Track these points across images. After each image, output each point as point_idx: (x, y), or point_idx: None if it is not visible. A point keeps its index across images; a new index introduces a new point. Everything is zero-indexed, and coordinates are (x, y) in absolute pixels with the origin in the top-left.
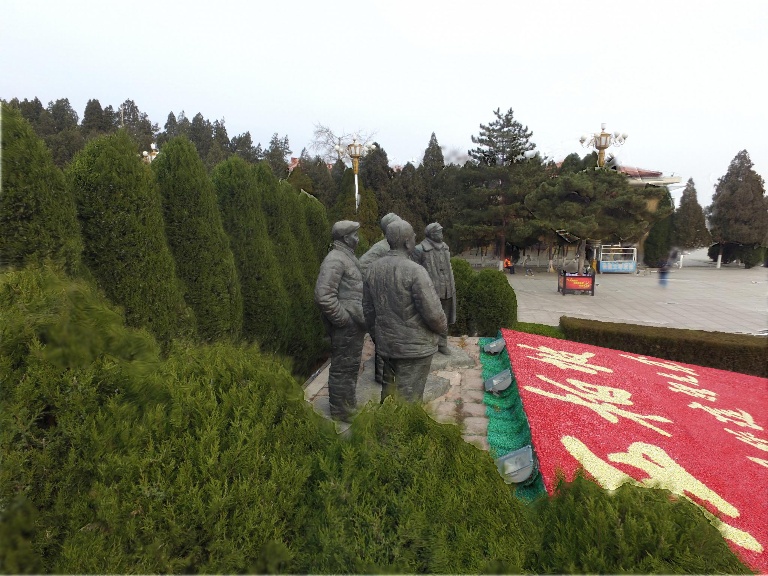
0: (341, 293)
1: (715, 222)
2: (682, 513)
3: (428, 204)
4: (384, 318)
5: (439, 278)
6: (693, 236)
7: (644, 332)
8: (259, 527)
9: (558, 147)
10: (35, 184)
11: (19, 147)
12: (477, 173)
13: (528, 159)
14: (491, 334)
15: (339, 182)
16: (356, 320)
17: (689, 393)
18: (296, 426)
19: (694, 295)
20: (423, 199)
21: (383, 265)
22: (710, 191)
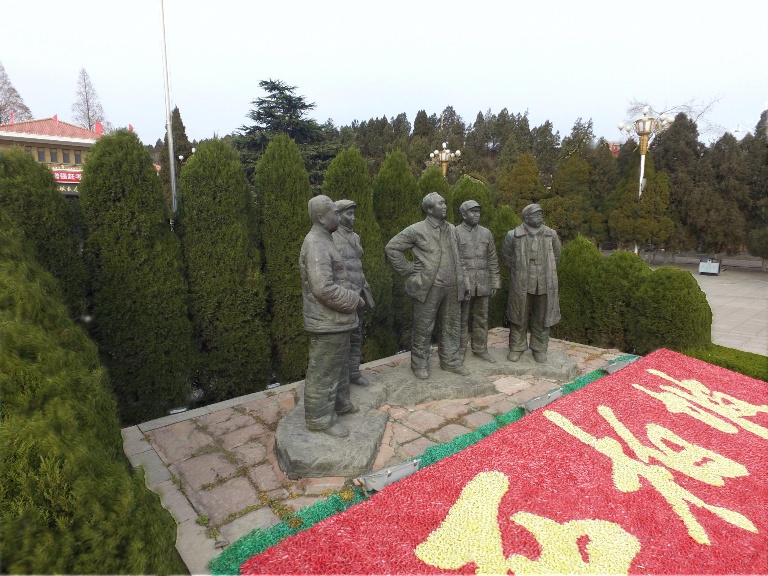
0: None
1: None
2: (6, 462)
3: (752, 187)
4: None
5: (528, 269)
6: None
7: None
8: None
9: None
10: (124, 178)
11: (119, 155)
12: None
13: None
14: None
15: (623, 165)
16: None
17: None
18: None
19: None
20: (744, 180)
21: None
22: None
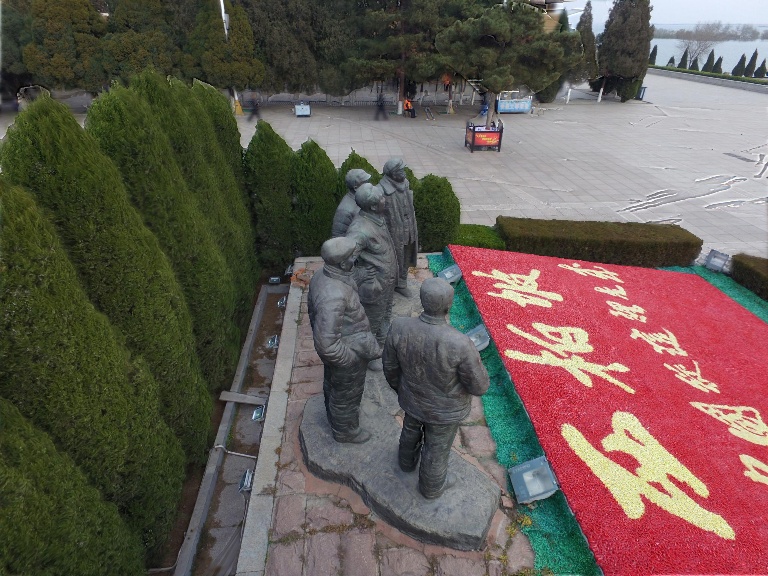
0: (343, 330)
1: (604, 53)
2: None
3: (314, 27)
4: (419, 388)
5: (403, 225)
6: (583, 69)
7: (576, 234)
8: None
9: None
10: None
11: None
12: None
13: None
14: (436, 248)
15: None
16: (363, 357)
17: (626, 315)
18: None
19: (586, 146)
20: (307, 20)
21: (419, 336)
22: (604, 17)
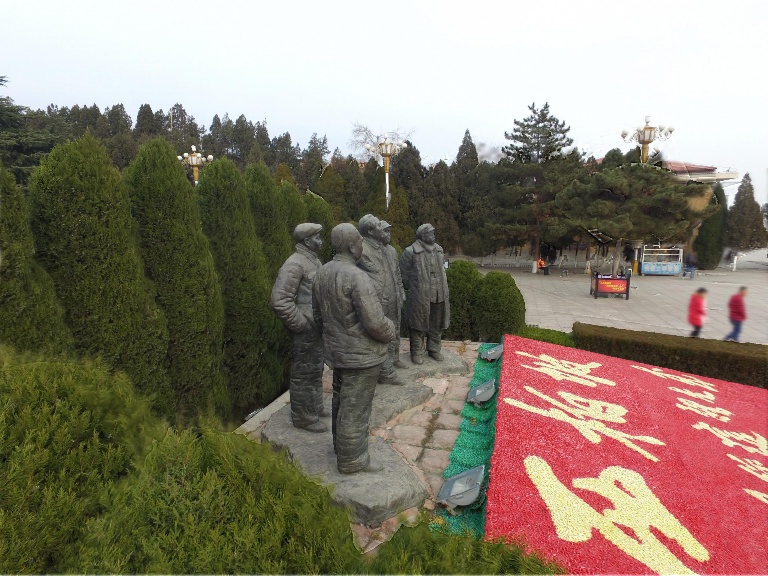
0: (300, 297)
1: None
2: None
3: (460, 203)
4: (327, 326)
5: (429, 281)
6: (748, 236)
7: (663, 342)
8: (2, 567)
9: (598, 142)
10: None
11: None
12: (510, 170)
13: (565, 155)
14: (495, 339)
15: (370, 181)
16: (314, 326)
17: (699, 411)
18: (104, 451)
19: (742, 300)
20: (455, 197)
21: (327, 270)
22: None
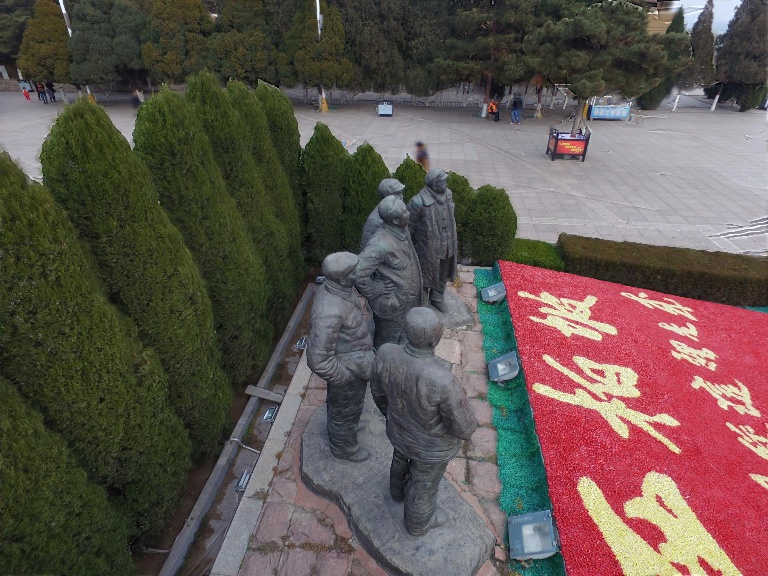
0: (339, 347)
1: (723, 56)
2: None
3: (405, 27)
4: (401, 421)
5: (441, 238)
6: (696, 74)
7: (647, 260)
8: None
9: None
10: None
11: None
12: None
13: None
14: (486, 262)
15: None
16: (359, 377)
17: (691, 359)
18: None
19: (687, 160)
20: (399, 21)
21: (401, 367)
22: (728, 15)
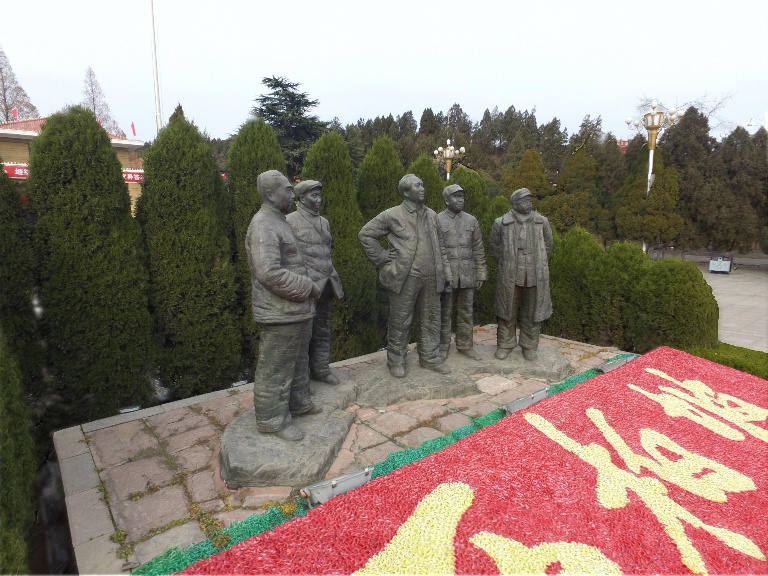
0: None
1: None
2: None
3: (765, 182)
4: None
5: (516, 259)
6: None
7: None
8: None
9: None
10: (75, 158)
11: (69, 133)
12: None
13: None
14: None
15: (631, 161)
16: None
17: None
18: None
19: None
20: (756, 176)
21: None
22: None
